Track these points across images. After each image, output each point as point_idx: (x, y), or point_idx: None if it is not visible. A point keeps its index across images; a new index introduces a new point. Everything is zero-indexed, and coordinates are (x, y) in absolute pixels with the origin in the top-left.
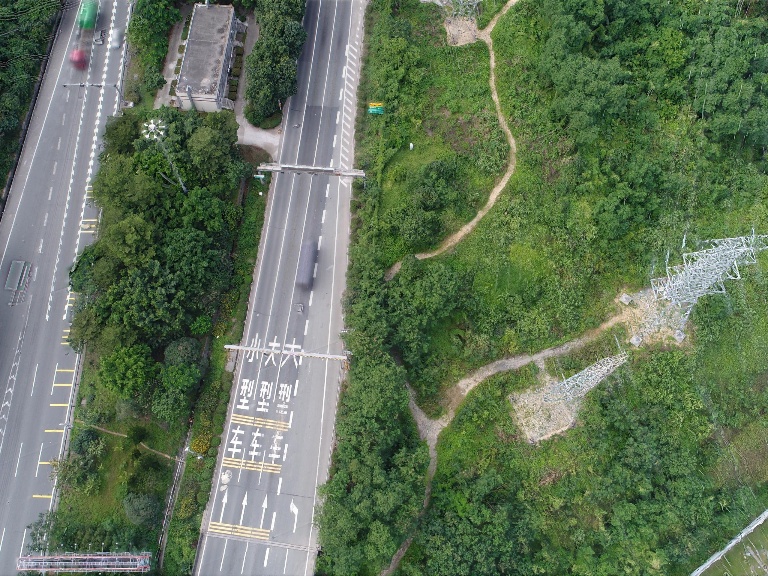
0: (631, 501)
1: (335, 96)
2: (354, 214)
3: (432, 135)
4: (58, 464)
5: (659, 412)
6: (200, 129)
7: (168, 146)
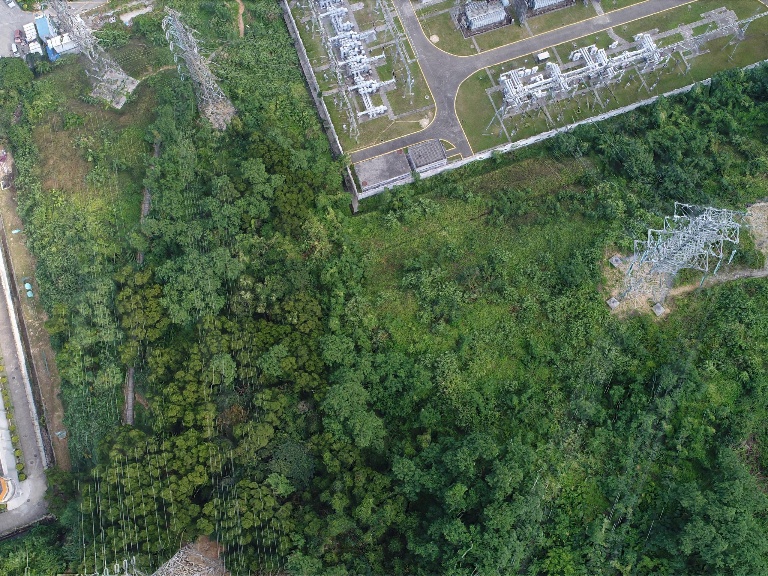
0: None
1: None
2: None
3: None
4: None
5: None
6: None
7: None
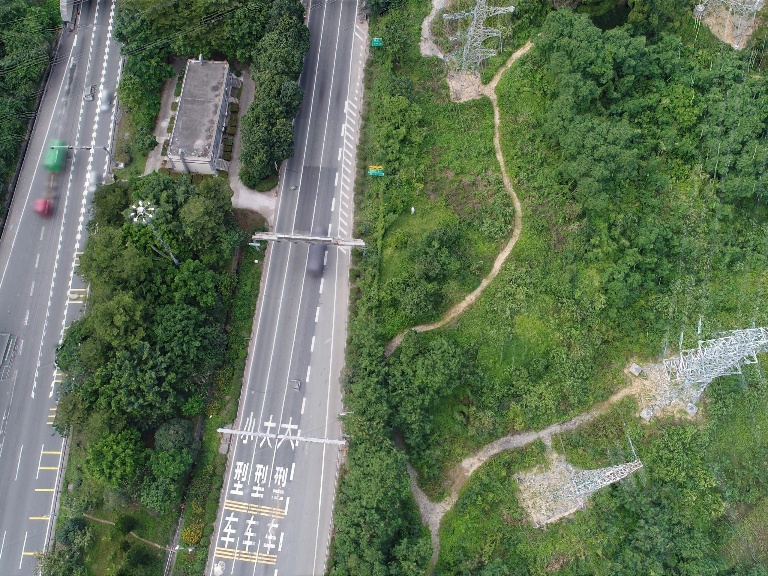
0: None
1: (334, 156)
2: (353, 283)
3: (434, 198)
4: (43, 557)
5: (671, 491)
6: (192, 199)
7: (159, 217)
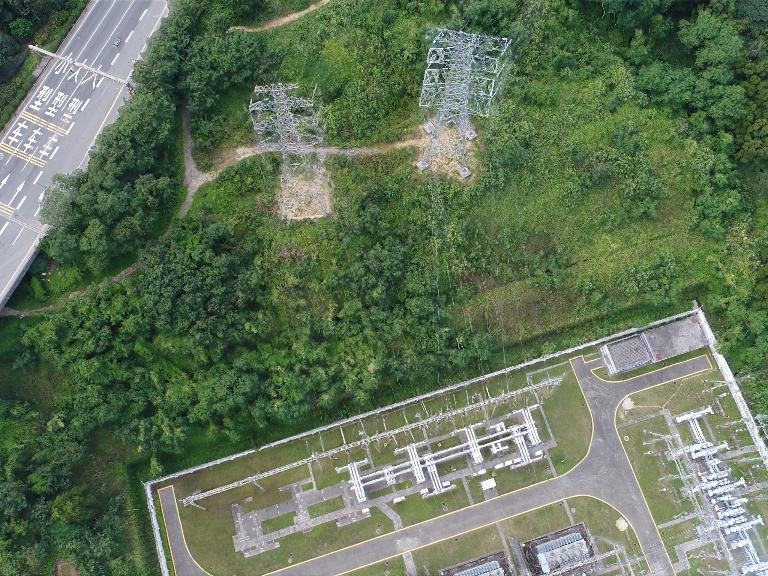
0: (368, 306)
1: None
2: None
3: None
4: None
5: (418, 232)
6: None
7: None
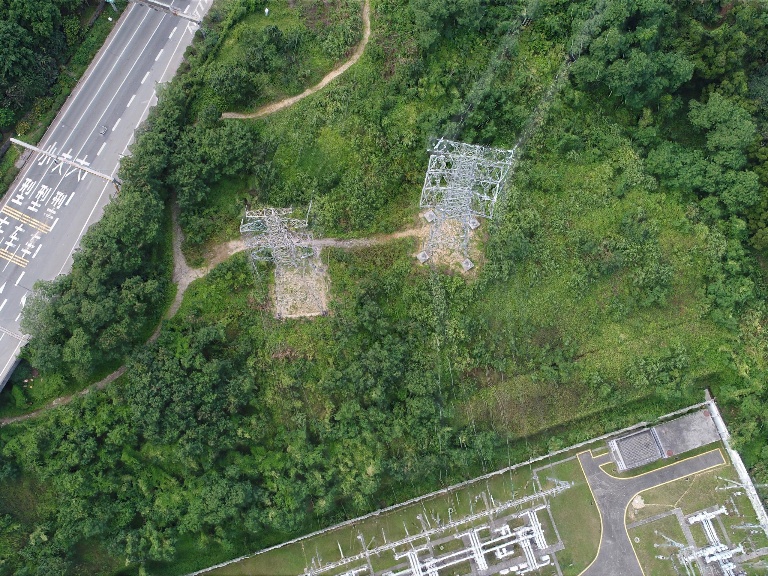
0: (366, 405)
1: None
2: (187, 60)
3: (293, 7)
4: None
5: (418, 329)
6: None
7: None
